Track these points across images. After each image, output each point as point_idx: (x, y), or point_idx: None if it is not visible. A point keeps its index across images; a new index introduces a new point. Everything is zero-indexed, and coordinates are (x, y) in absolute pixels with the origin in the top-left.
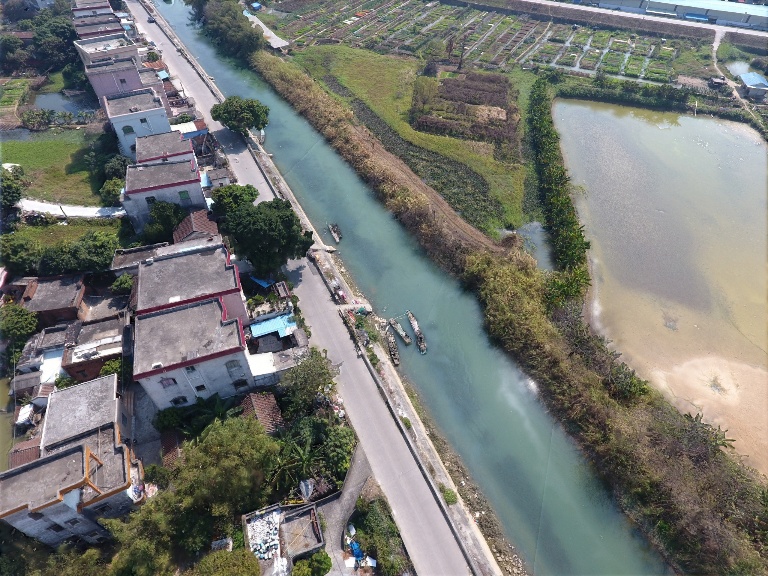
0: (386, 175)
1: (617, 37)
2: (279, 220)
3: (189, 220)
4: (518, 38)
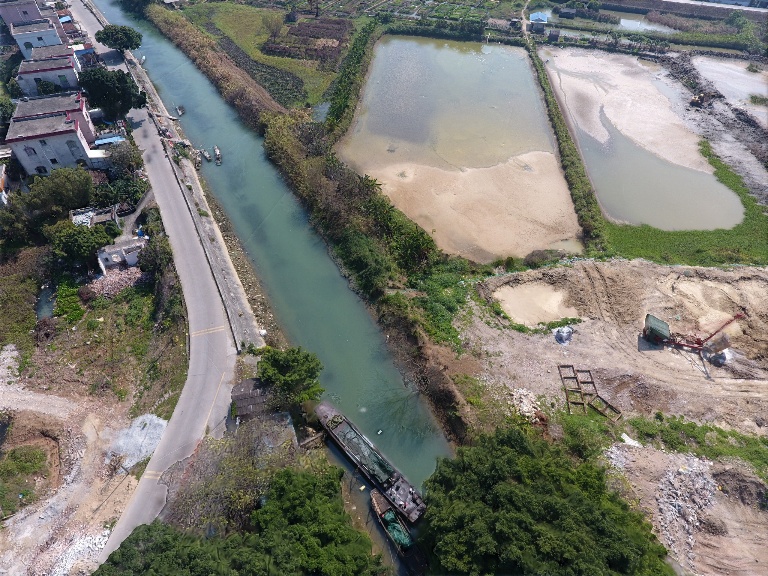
0: (223, 75)
1: None
2: (115, 77)
3: None
4: None
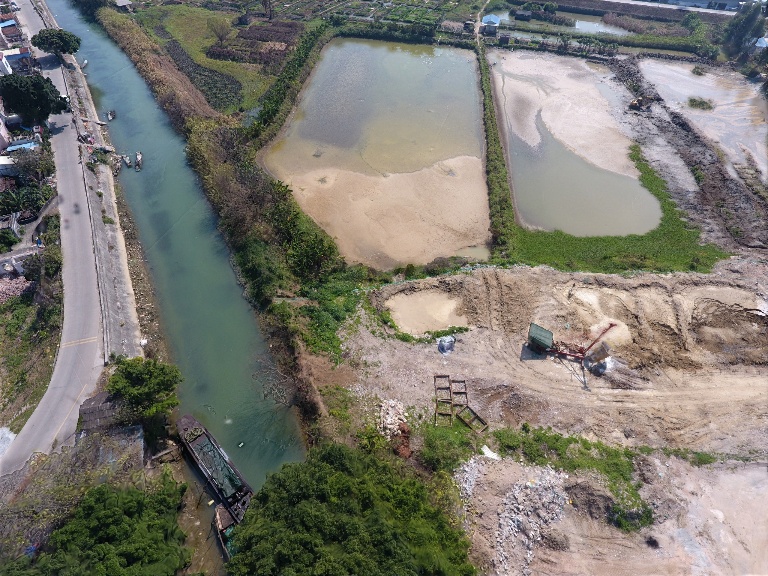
0: (158, 79)
1: None
2: (30, 83)
3: None
4: None
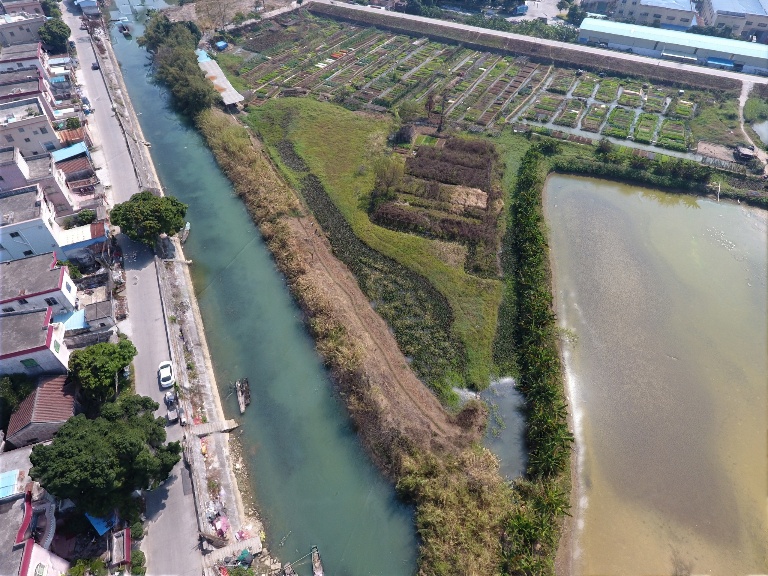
0: (319, 307)
1: (627, 87)
2: (113, 451)
3: (32, 399)
4: (512, 88)
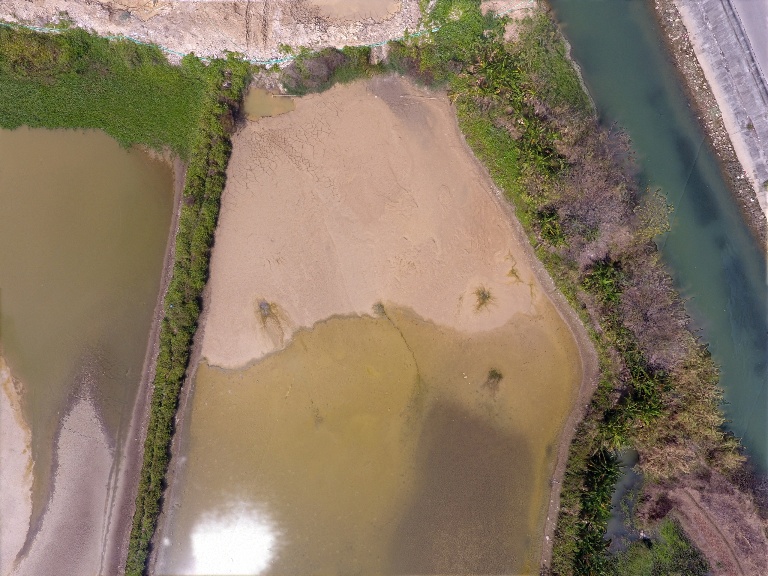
0: None
1: None
2: None
3: None
4: None
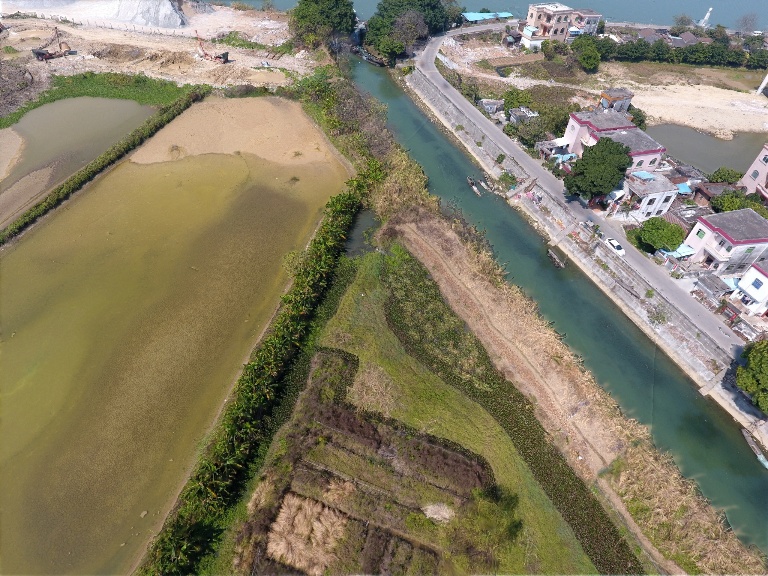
0: None
1: None
2: None
3: None
4: None
